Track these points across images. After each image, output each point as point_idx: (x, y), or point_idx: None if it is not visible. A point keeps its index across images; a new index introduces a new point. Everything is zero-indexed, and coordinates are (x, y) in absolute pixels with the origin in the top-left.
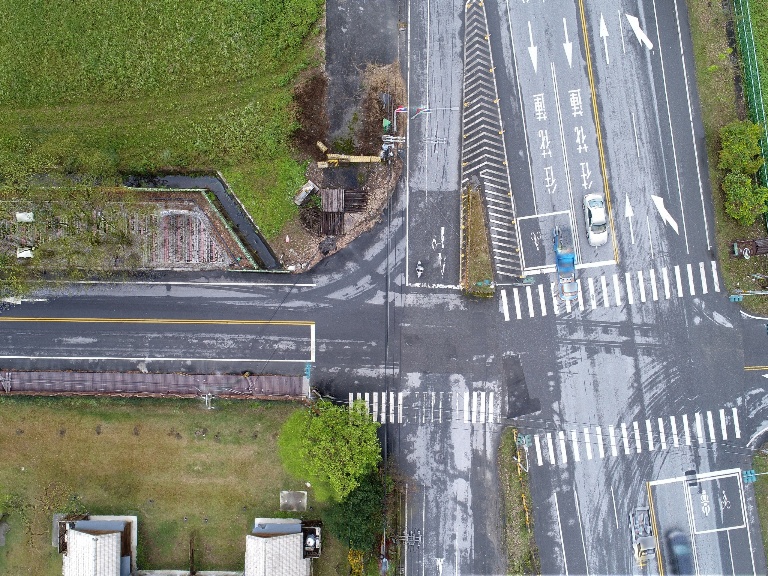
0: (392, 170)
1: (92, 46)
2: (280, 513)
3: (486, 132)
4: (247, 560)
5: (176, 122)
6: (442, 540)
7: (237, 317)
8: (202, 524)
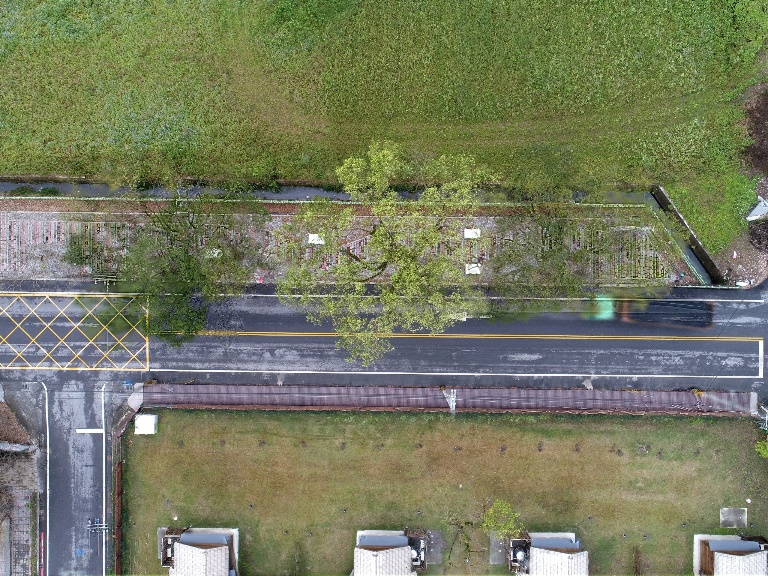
0: None
1: (539, 61)
2: (720, 530)
3: None
4: None
5: (620, 137)
6: None
7: (685, 333)
8: (641, 541)
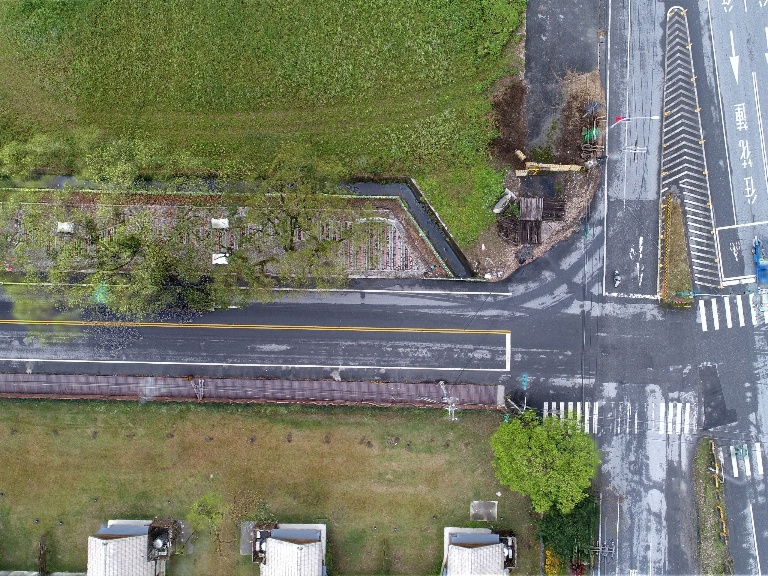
0: (590, 179)
1: (289, 52)
2: (470, 523)
3: (686, 141)
4: (450, 570)
5: (371, 129)
6: (636, 551)
7: (432, 325)
8: (391, 533)
